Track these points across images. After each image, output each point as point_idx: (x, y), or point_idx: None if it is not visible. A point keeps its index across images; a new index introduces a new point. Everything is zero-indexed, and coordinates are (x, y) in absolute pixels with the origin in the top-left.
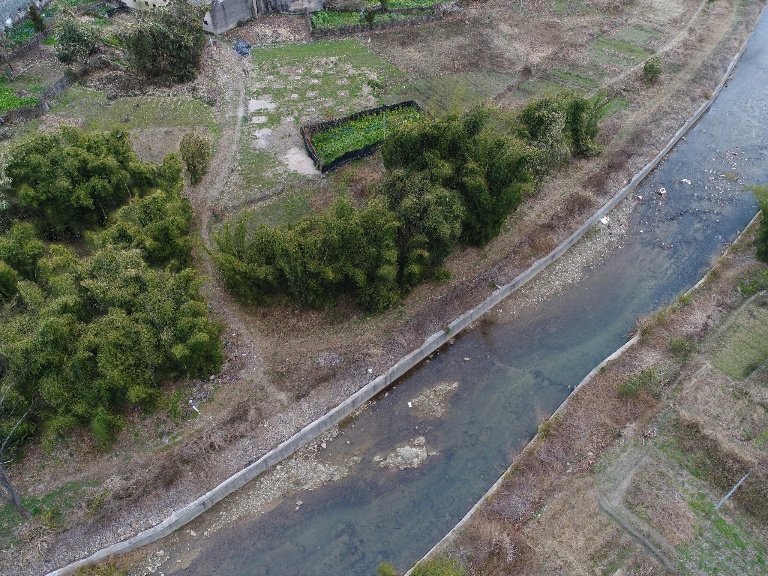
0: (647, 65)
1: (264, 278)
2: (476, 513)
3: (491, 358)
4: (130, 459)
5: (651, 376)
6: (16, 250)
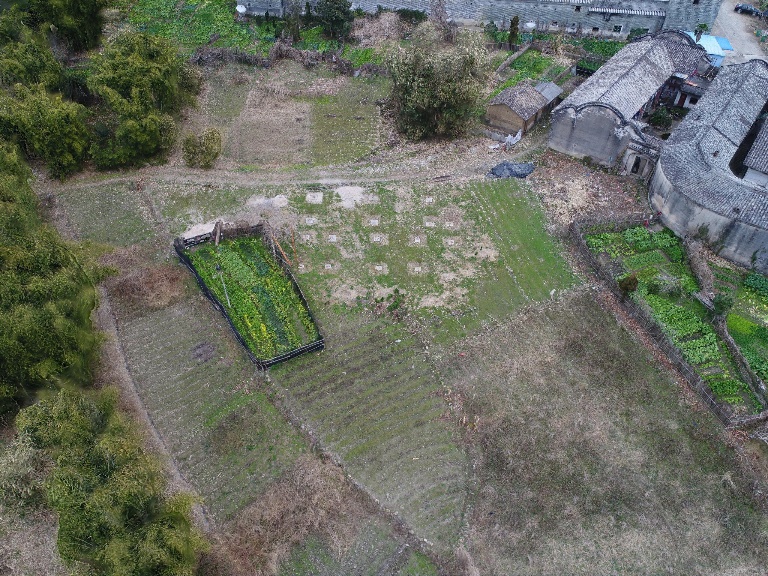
0: None
1: None
2: None
3: None
4: None
5: None
6: (36, 68)
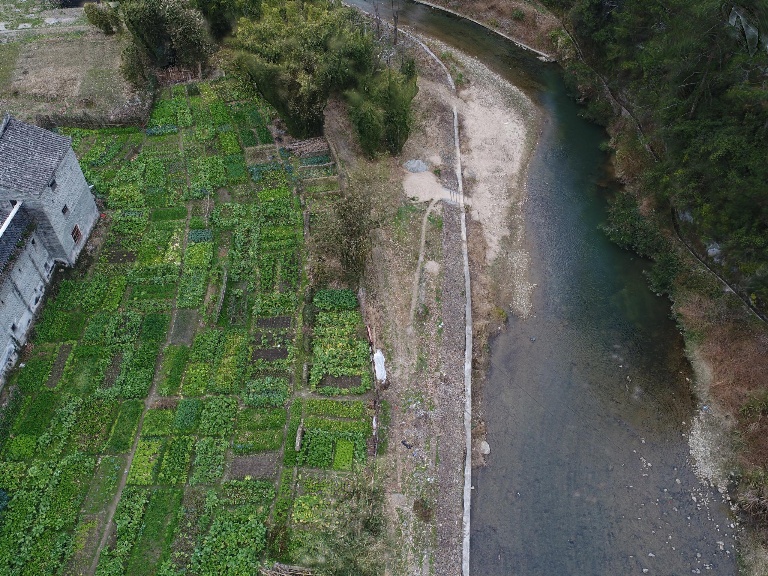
0: None
1: None
2: None
3: None
4: None
5: None
6: None
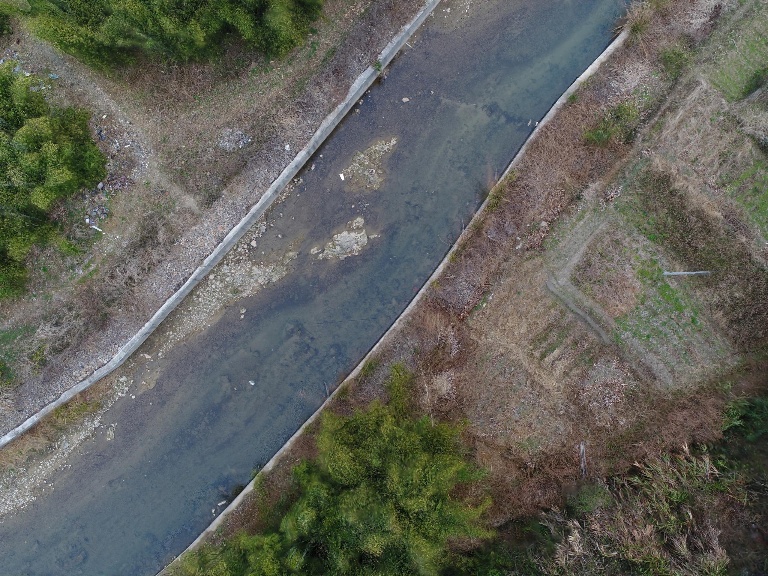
0: None
1: (110, 43)
2: (422, 301)
3: (436, 93)
4: (51, 298)
5: (629, 115)
6: None
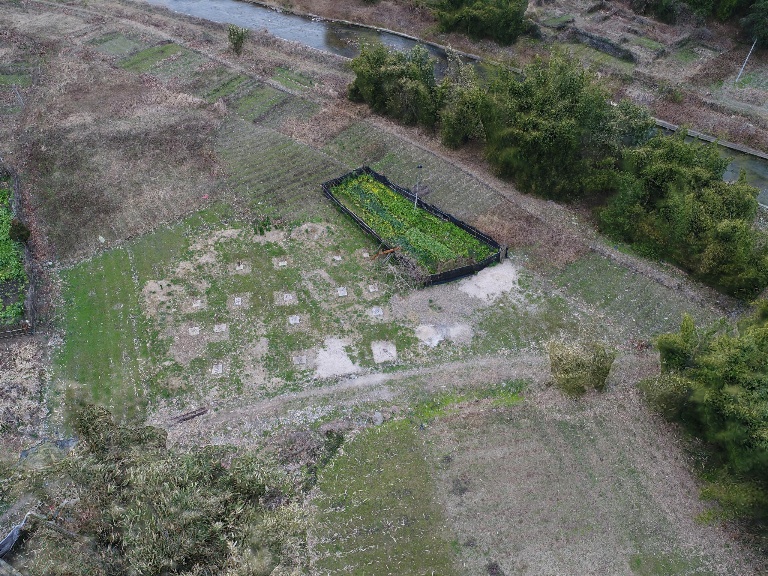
0: (240, 35)
1: None
2: None
3: None
4: None
5: None
6: None
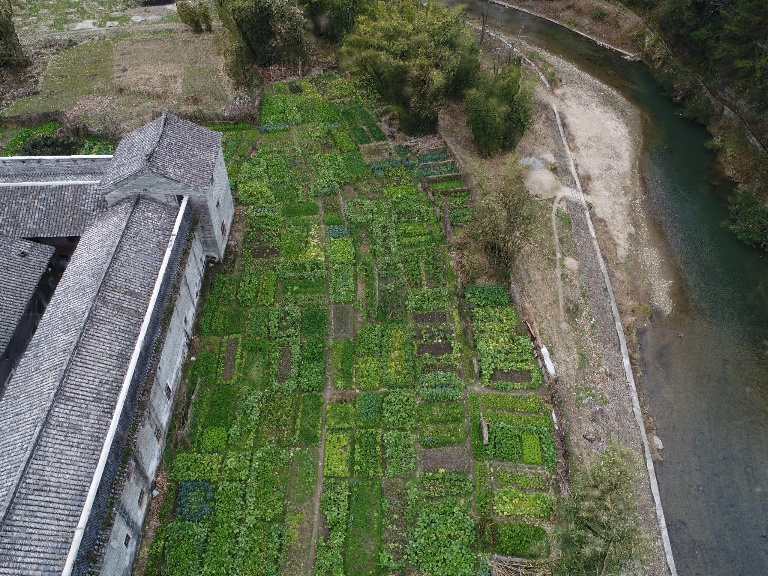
0: None
1: None
2: None
3: None
4: None
5: None
6: None
